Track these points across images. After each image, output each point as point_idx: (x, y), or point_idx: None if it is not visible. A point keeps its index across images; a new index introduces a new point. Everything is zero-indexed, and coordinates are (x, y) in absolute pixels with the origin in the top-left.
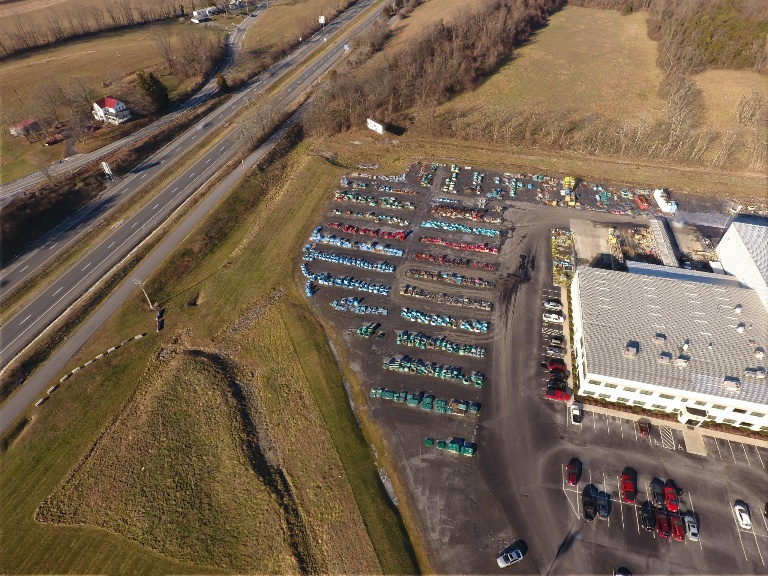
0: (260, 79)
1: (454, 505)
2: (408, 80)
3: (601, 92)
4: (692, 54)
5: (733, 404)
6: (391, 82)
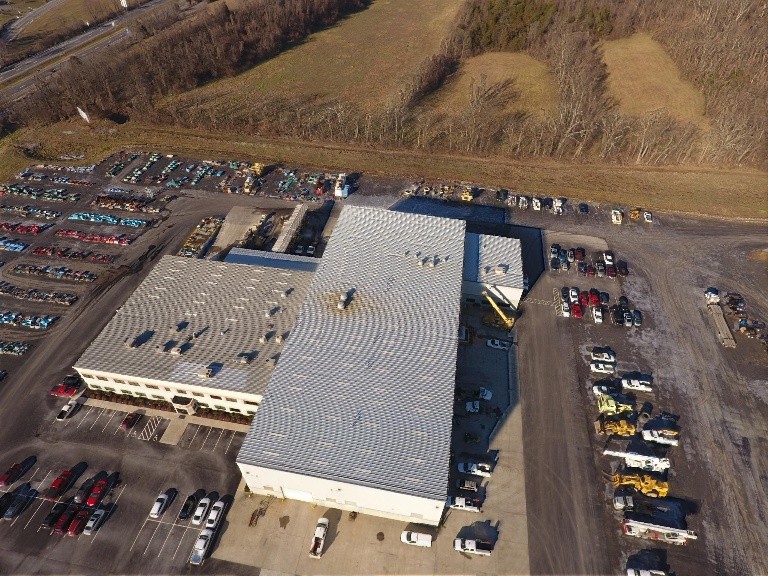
0: (15, 66)
1: None
2: (149, 66)
3: (365, 76)
4: (461, 37)
5: (205, 391)
6: (139, 68)
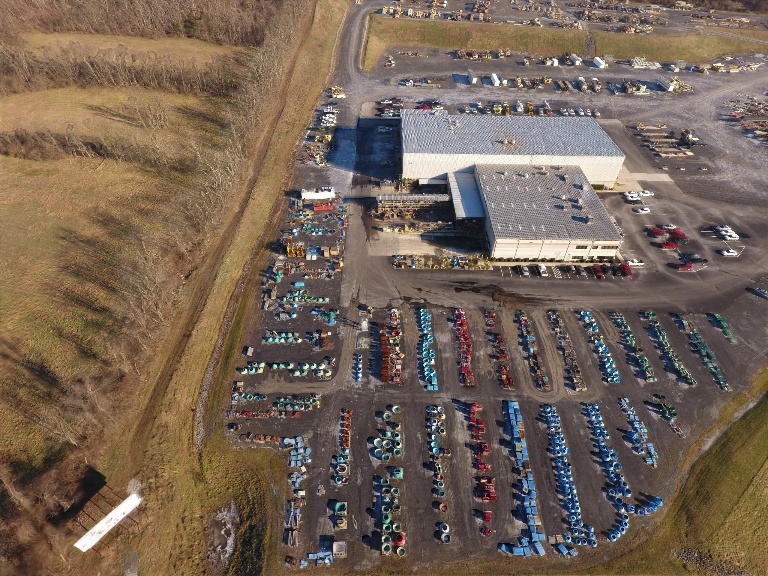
0: None
1: (761, 322)
2: None
3: (0, 203)
4: None
5: None
6: None
